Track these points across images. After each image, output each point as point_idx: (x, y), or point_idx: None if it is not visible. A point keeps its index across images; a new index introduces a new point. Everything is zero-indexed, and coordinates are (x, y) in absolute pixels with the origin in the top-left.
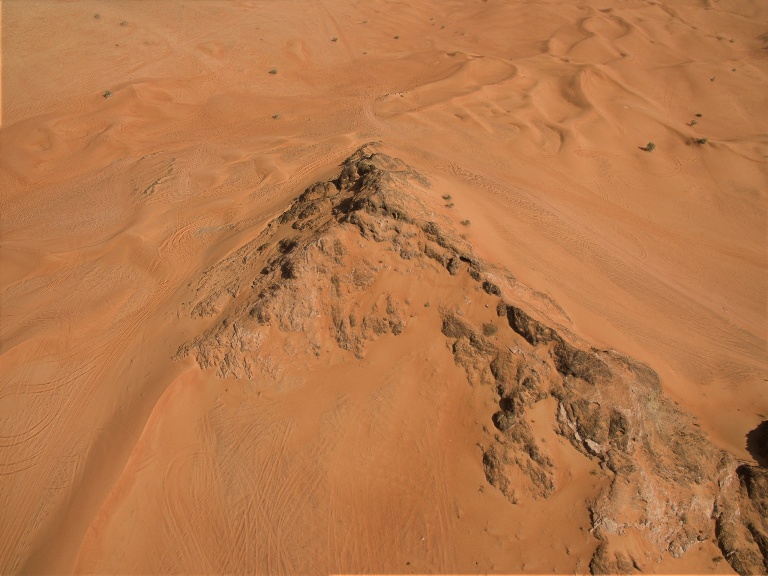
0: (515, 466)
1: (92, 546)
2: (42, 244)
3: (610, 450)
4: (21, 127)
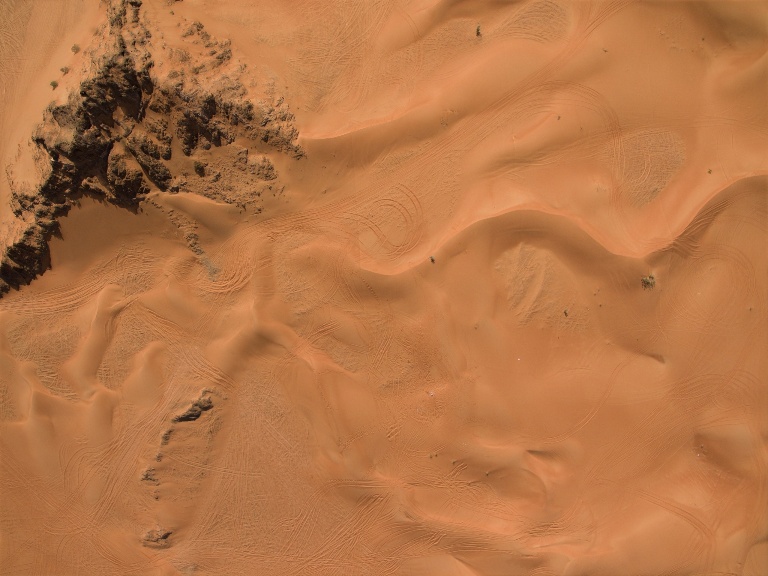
0: None
1: (397, 115)
2: (314, 404)
3: None
4: None
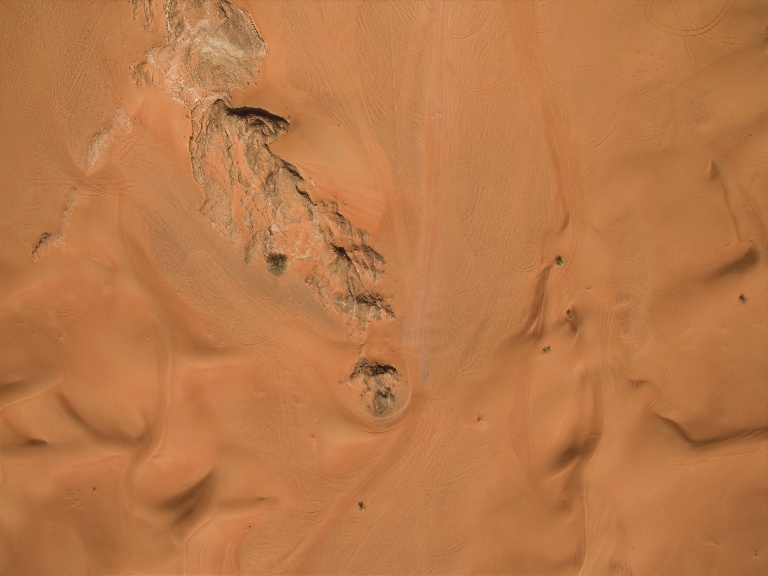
0: (143, 5)
1: None
2: None
3: (172, 34)
4: None
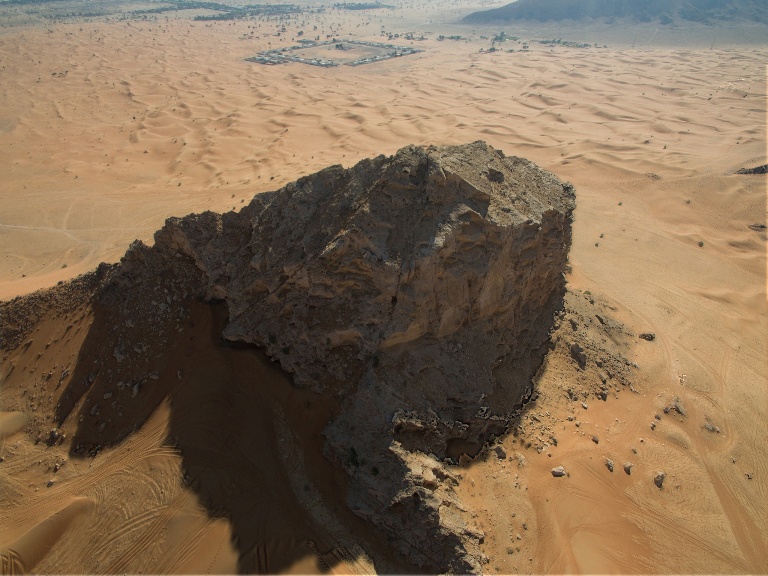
0: None
1: None
2: None
3: None
4: (760, 269)
